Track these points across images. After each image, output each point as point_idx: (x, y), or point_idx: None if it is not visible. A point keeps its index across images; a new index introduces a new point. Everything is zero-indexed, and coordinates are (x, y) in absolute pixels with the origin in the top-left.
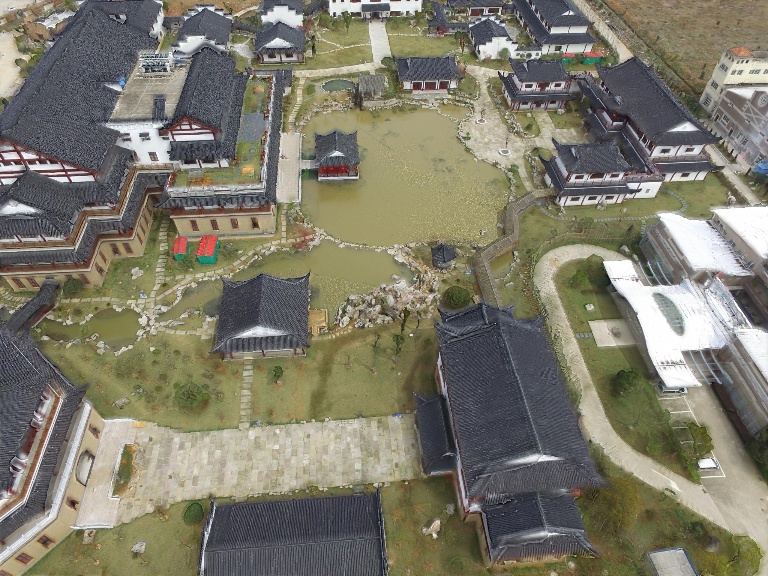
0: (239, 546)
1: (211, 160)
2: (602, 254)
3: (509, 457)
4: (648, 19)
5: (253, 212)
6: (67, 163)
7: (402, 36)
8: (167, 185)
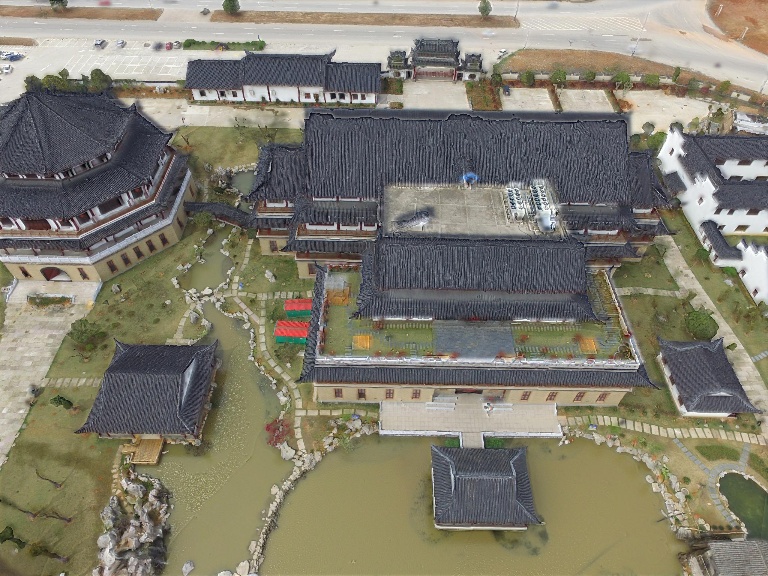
0: None
1: None
2: None
3: None
4: None
5: None
6: None
7: None
8: None
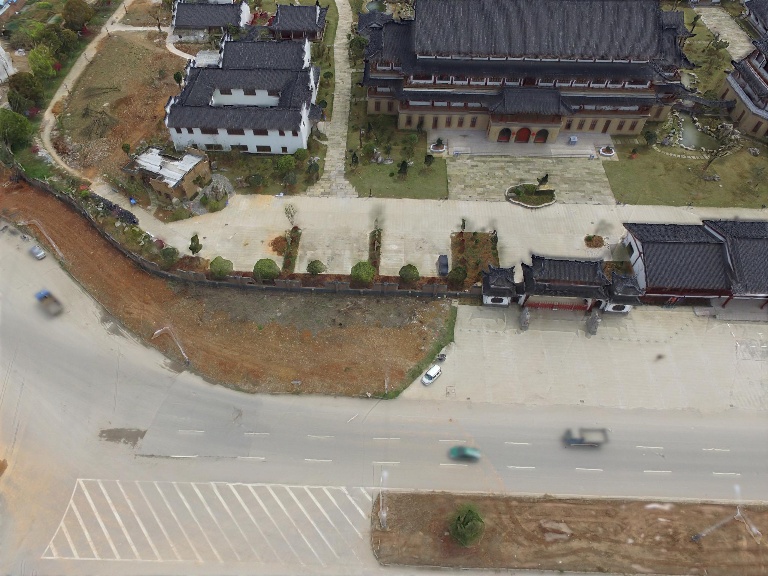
0: None
1: None
2: None
3: None
4: None
5: None
6: None
7: None
8: None
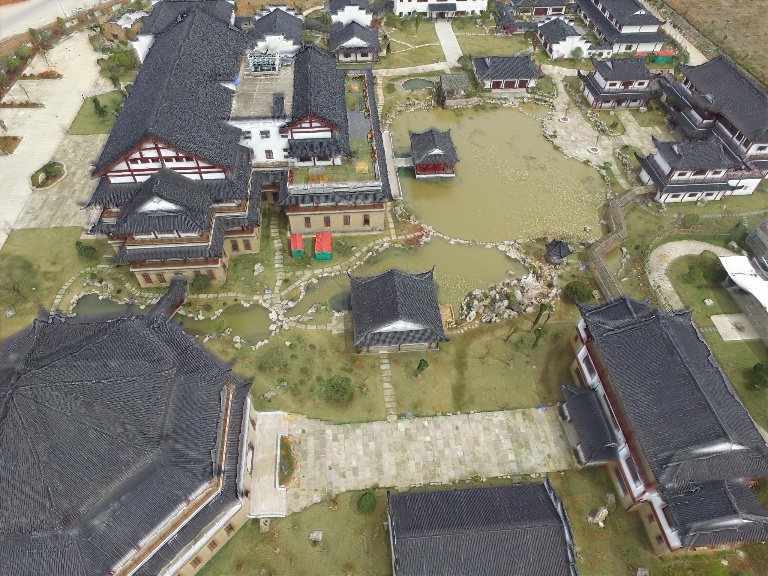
0: (427, 533)
1: (326, 158)
2: (710, 250)
3: (696, 446)
4: (710, 18)
5: (367, 209)
6: (204, 160)
7: (470, 35)
8: (287, 182)
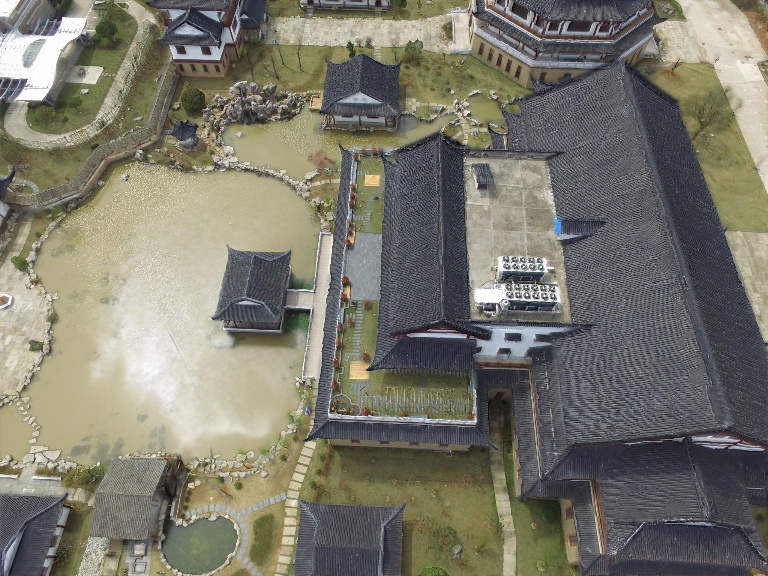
0: None
1: None
2: None
3: None
4: None
5: None
6: None
7: None
8: None
